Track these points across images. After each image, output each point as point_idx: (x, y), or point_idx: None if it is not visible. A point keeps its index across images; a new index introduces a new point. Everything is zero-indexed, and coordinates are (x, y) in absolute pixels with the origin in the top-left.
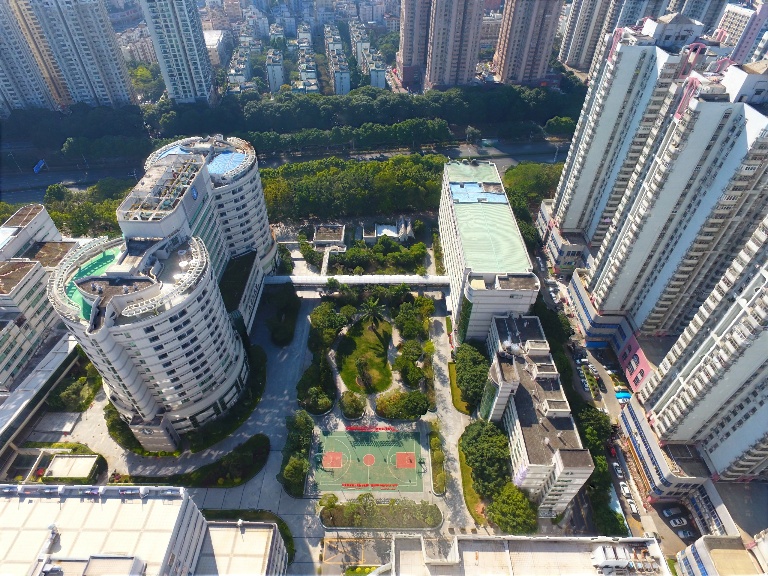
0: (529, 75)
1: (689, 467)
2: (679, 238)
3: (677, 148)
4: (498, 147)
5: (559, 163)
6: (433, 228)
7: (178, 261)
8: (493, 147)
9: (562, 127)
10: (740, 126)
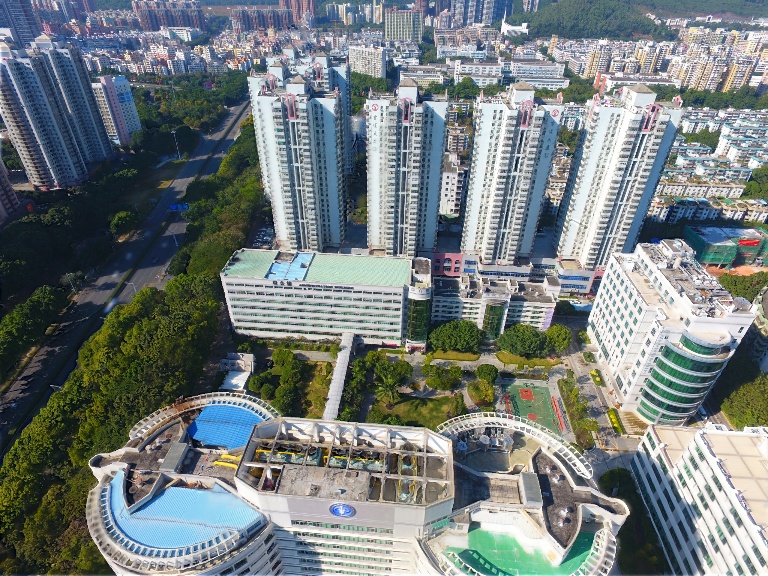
0: (10, 205)
1: (523, 263)
2: (428, 185)
3: (420, 137)
4: (106, 274)
5: (204, 236)
6: (251, 340)
7: (466, 460)
8: (103, 277)
9: (130, 221)
10: (431, 112)
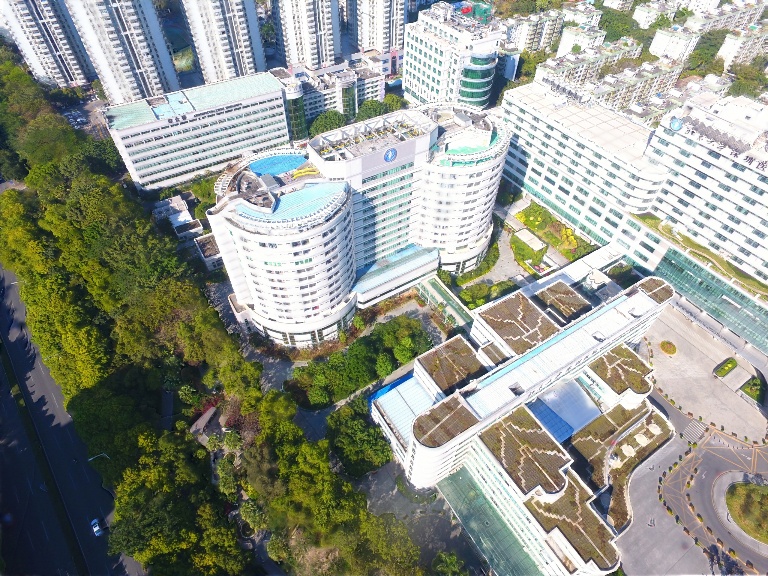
0: None
1: (339, 62)
2: (244, 4)
3: None
4: None
5: (15, 130)
6: None
7: None
8: None
9: None
10: None
